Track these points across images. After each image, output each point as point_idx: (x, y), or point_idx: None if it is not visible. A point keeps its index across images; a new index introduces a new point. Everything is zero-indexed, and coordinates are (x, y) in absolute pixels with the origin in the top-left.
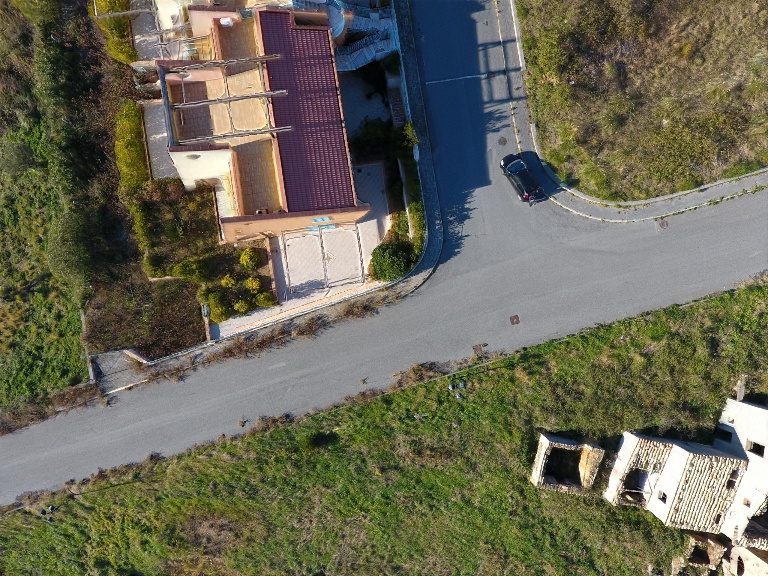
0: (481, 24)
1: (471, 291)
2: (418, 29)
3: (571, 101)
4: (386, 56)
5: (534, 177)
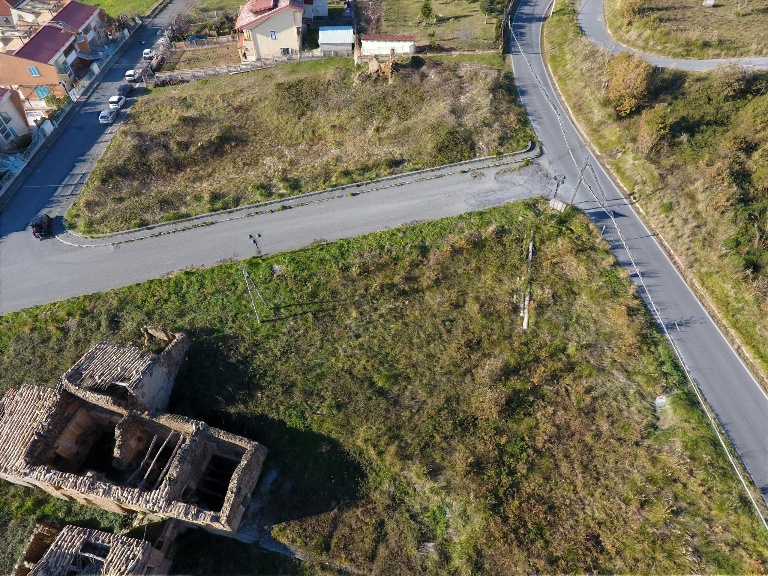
0: (77, 167)
1: None
2: (39, 168)
3: (98, 192)
4: (1, 172)
5: (54, 227)
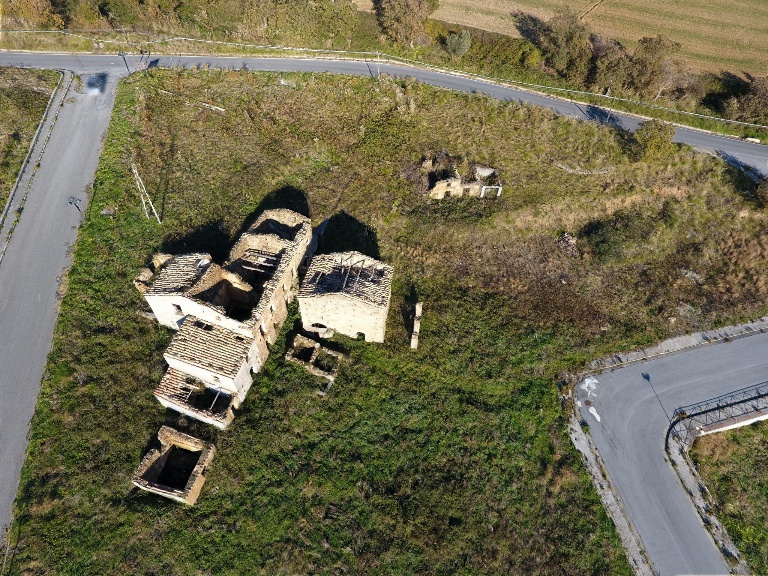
0: None
1: None
2: None
3: None
4: None
5: None
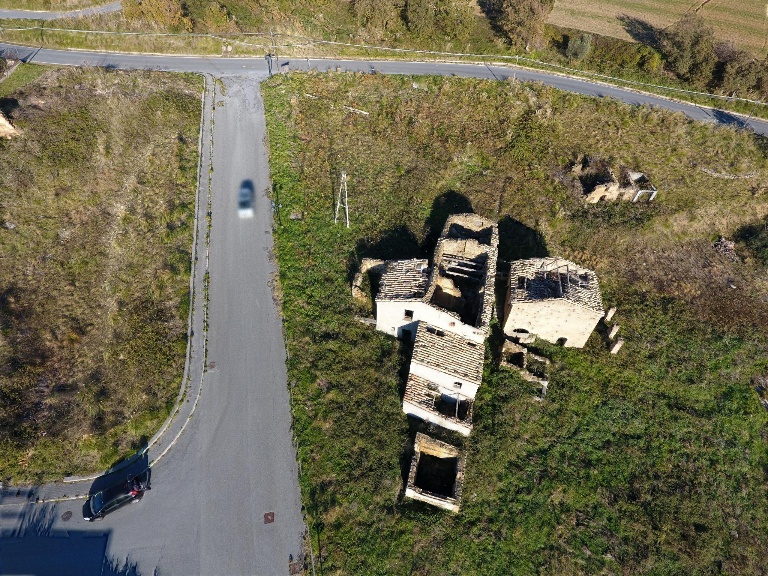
0: None
1: (223, 572)
2: None
3: (59, 437)
4: None
5: None
